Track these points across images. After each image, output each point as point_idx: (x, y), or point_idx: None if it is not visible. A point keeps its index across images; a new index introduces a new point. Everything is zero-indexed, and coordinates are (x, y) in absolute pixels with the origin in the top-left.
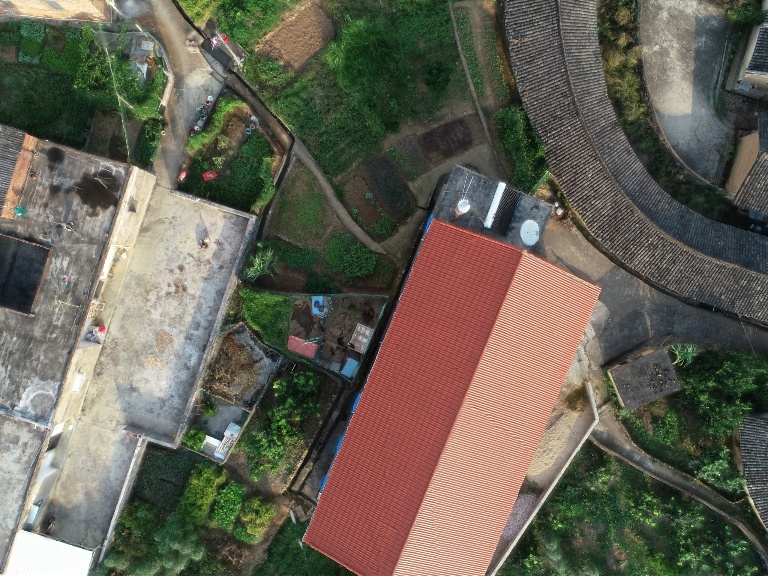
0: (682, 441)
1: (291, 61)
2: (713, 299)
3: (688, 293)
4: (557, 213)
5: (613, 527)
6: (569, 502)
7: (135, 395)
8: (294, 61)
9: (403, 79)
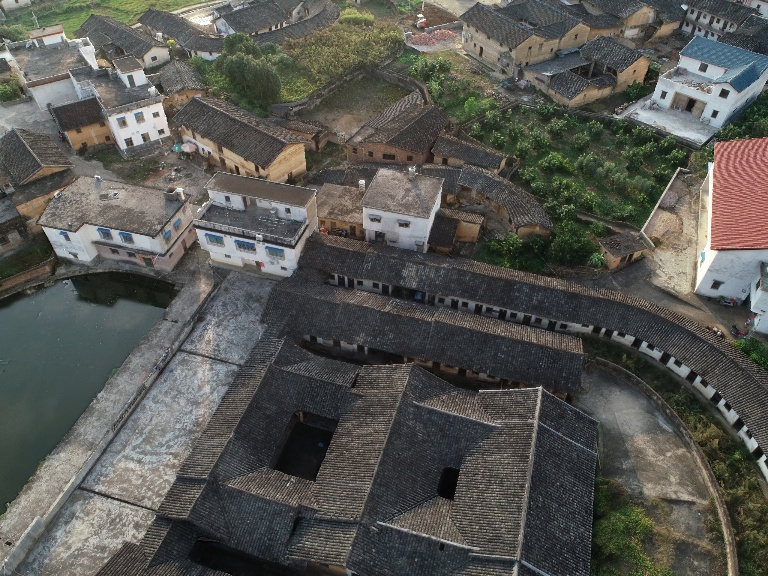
0: None
1: None
2: None
3: None
4: (717, 328)
5: None
6: None
7: None
8: None
9: None
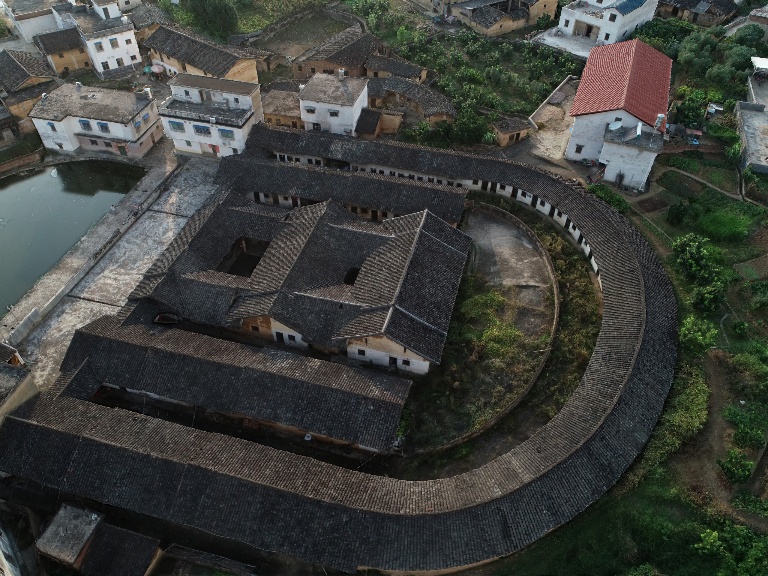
0: None
1: (767, 229)
2: None
3: None
4: (576, 179)
5: None
6: None
7: (767, 119)
8: (765, 229)
9: (697, 212)
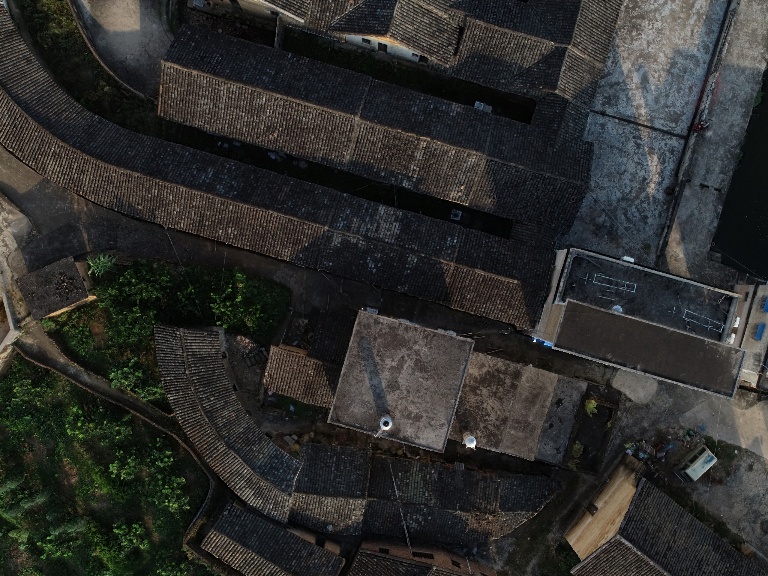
0: (122, 355)
1: None
2: (133, 210)
3: (108, 204)
4: None
5: (62, 442)
6: (14, 417)
7: None
8: None
9: None
